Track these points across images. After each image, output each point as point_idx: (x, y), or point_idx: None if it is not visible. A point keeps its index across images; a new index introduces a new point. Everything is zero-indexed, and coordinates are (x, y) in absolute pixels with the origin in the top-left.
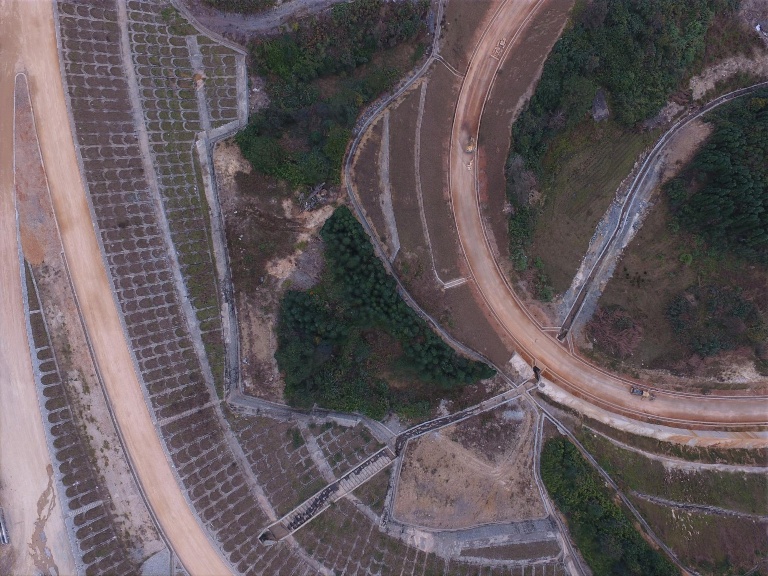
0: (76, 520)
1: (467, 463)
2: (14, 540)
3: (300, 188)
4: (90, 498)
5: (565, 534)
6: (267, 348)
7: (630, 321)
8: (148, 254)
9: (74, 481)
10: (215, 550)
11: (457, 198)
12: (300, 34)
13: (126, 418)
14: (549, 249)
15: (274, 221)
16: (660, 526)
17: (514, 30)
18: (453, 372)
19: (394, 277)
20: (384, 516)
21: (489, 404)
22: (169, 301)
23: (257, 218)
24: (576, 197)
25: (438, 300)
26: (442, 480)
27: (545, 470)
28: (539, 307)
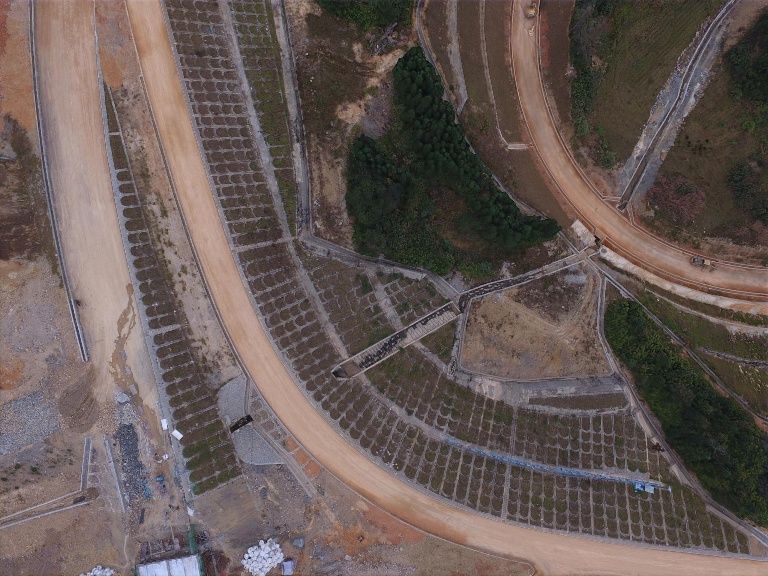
0: (156, 339)
1: (531, 322)
2: (94, 358)
3: (372, 28)
4: (168, 320)
5: (631, 389)
6: (337, 192)
7: (693, 186)
8: (223, 86)
9: (153, 302)
10: (291, 377)
11: (518, 64)
12: None
13: (203, 244)
14: (610, 117)
15: (345, 63)
16: (729, 377)
17: None
18: (519, 227)
19: None
20: (452, 365)
21: (551, 269)
22: (243, 134)
23: (328, 60)
24: (637, 65)
25: (502, 159)
26: (507, 335)
27: (610, 328)
28: (600, 175)
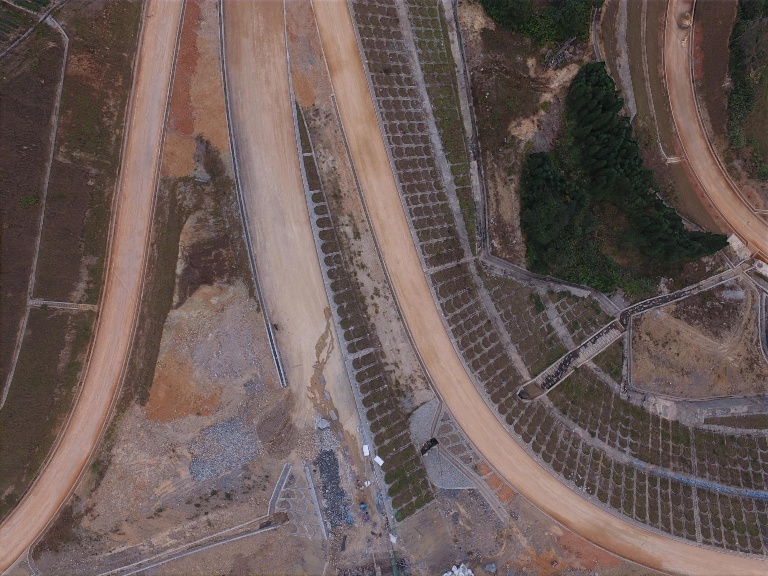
0: (354, 363)
1: (693, 339)
2: (292, 383)
3: (551, 43)
4: (364, 344)
5: None
6: (510, 210)
7: None
8: (408, 104)
9: (349, 326)
10: (485, 400)
11: (671, 76)
12: None
13: (395, 265)
14: (763, 129)
15: (520, 79)
16: None
17: None
18: (685, 243)
19: None
20: (624, 384)
21: (707, 284)
22: (427, 153)
23: (503, 76)
24: None
25: (663, 173)
26: (673, 353)
27: None
28: (753, 188)
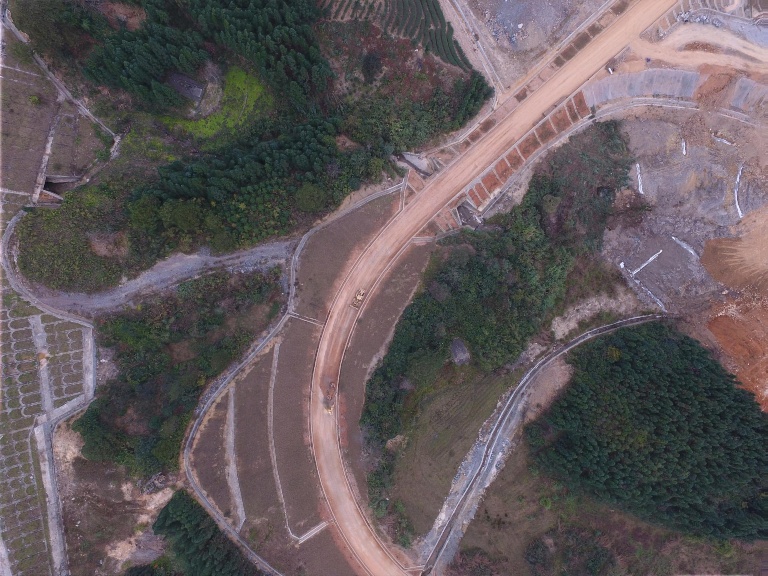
0: None
1: None
2: None
3: None
4: None
5: None
6: None
7: (487, 569)
8: None
9: None
10: None
11: (318, 442)
12: (145, 311)
13: None
14: (411, 491)
15: (112, 506)
16: None
17: (373, 280)
18: None
19: (242, 544)
20: None
21: None
22: None
23: (95, 504)
24: (438, 438)
25: (291, 558)
26: None
27: None
28: (400, 549)
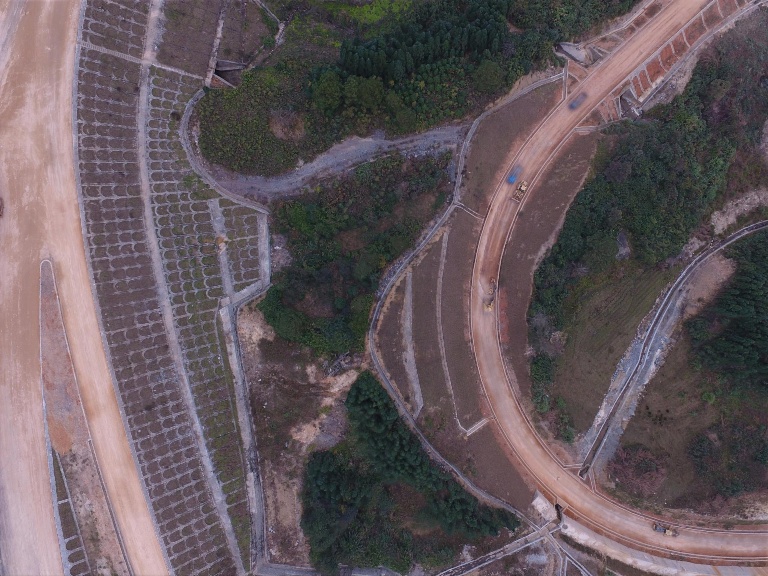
0: None
1: None
2: None
3: (324, 357)
4: None
5: None
6: (292, 513)
7: (653, 463)
8: (174, 433)
9: None
10: None
11: (478, 338)
12: (322, 195)
13: None
14: (571, 387)
15: (298, 388)
16: None
17: (535, 172)
18: (477, 525)
19: (417, 432)
20: None
21: (512, 547)
22: (195, 478)
23: (281, 385)
24: (597, 335)
25: (461, 449)
26: None
27: None
28: (561, 446)
